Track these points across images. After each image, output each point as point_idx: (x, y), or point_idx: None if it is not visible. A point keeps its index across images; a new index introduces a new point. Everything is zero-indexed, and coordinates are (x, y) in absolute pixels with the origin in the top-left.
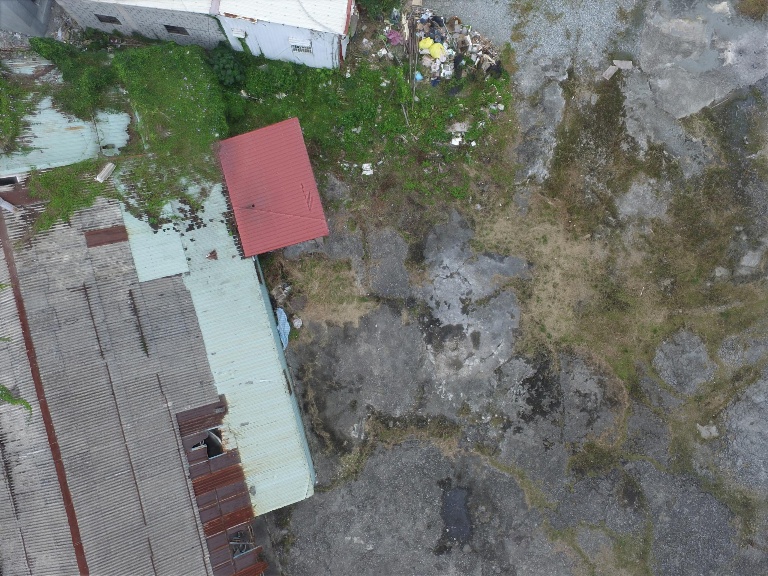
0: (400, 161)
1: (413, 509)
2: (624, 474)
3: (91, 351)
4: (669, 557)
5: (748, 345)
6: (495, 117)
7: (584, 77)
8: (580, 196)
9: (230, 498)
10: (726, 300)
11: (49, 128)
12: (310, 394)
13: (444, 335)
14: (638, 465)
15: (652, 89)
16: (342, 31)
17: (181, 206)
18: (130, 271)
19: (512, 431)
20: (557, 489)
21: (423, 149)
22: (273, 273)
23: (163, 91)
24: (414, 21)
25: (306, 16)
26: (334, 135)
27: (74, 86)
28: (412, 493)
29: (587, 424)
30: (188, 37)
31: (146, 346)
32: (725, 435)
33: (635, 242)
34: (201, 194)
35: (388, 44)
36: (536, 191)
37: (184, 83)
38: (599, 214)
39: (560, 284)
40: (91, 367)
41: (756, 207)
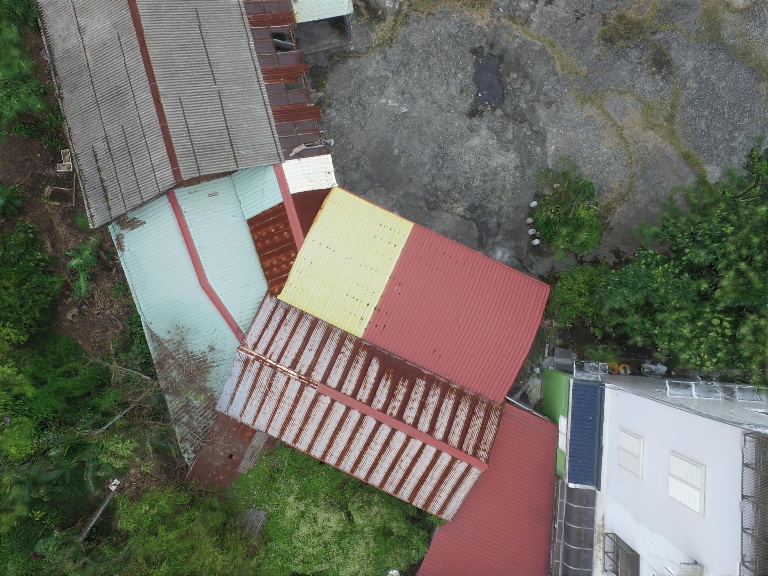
0: None
1: (446, 74)
2: (653, 43)
3: None
4: (696, 120)
5: None
6: None
7: None
8: None
9: (273, 0)
10: None
11: None
12: None
13: None
14: (667, 35)
15: None
16: None
17: None
18: None
19: (544, 2)
20: (587, 57)
21: None
22: None
23: None
24: None
25: None
26: None
27: None
28: (445, 59)
29: None
30: None
31: None
32: (752, 7)
33: None
34: None
35: None
36: None
37: None
38: None
39: None
40: None
41: None
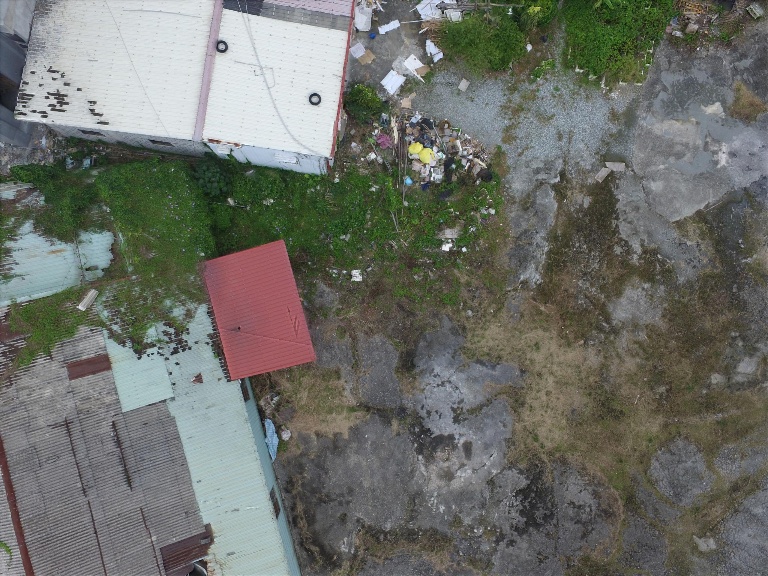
0: (390, 268)
1: None
2: None
3: (73, 489)
4: None
5: (745, 454)
6: (486, 221)
7: (576, 179)
8: (573, 302)
9: None
10: (722, 408)
11: (31, 253)
12: (299, 507)
13: (435, 445)
14: None
15: (645, 191)
16: (328, 154)
17: (166, 329)
18: (113, 401)
19: (505, 544)
20: None
21: (413, 256)
22: (261, 383)
23: (147, 211)
24: (403, 125)
25: (291, 139)
26: (322, 242)
27: (56, 209)
28: None
29: (581, 537)
30: (173, 148)
31: (129, 479)
32: (722, 547)
33: (629, 349)
34: (186, 316)
35: (377, 148)
36: (528, 297)
37: (168, 202)
38: (592, 320)
39: (553, 392)
40: (73, 506)
41: (752, 312)
